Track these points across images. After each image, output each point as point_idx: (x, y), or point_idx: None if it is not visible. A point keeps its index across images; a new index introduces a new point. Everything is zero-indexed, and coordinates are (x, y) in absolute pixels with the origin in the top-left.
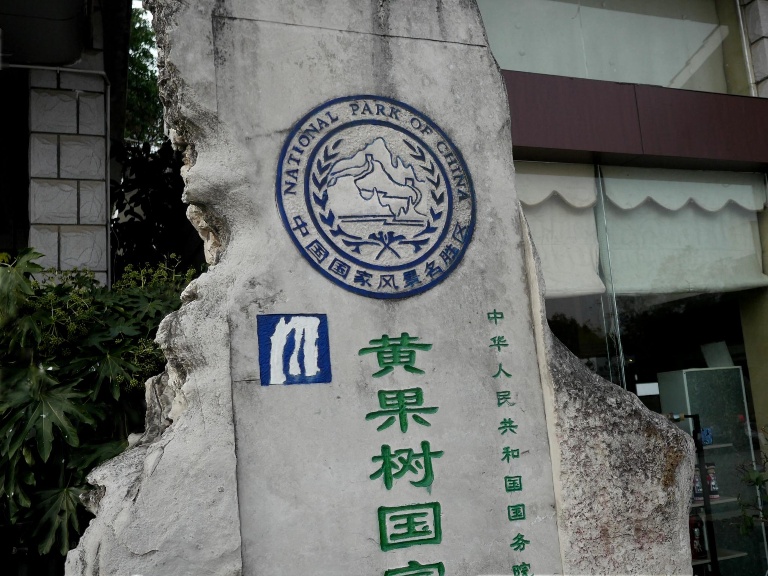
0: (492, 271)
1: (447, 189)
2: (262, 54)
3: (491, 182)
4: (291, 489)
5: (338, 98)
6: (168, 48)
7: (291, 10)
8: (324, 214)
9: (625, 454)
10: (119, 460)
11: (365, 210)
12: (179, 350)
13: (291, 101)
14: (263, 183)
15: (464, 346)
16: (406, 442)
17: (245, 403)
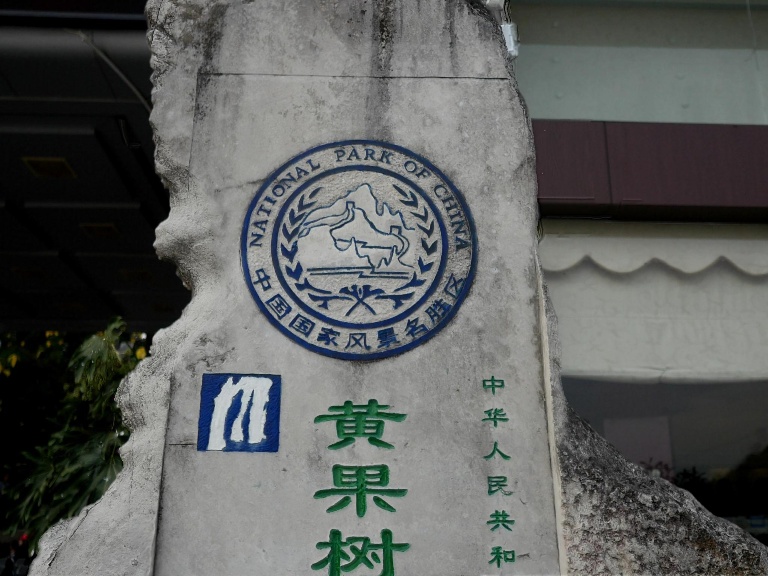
0: (493, 330)
1: (442, 237)
2: (244, 106)
3: (500, 228)
4: (216, 570)
5: (322, 145)
6: None
7: (281, 61)
8: (291, 267)
9: (664, 571)
10: (61, 521)
11: (339, 262)
12: (123, 408)
13: (269, 151)
14: (228, 236)
15: (448, 418)
16: (361, 528)
17: (177, 469)
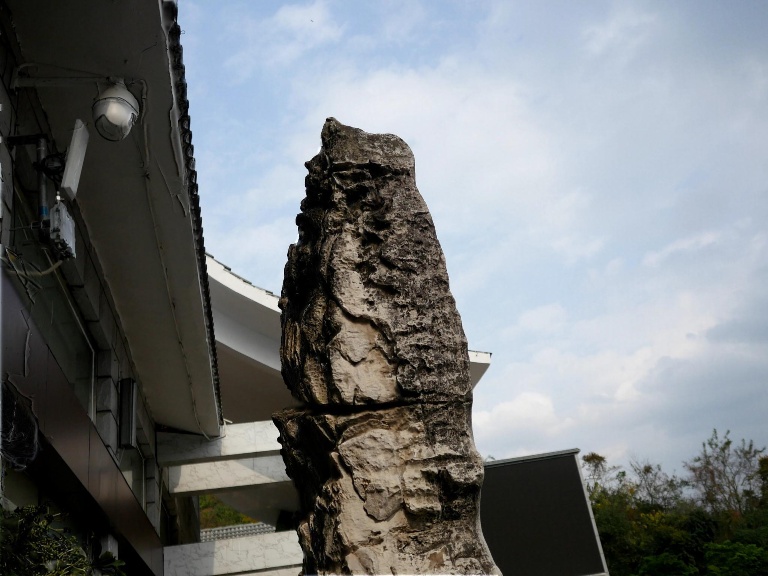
0: None
1: None
2: None
3: None
4: None
5: None
6: (454, 327)
7: None
8: None
9: None
10: None
11: None
12: None
13: None
14: None
15: None
16: None
17: None
